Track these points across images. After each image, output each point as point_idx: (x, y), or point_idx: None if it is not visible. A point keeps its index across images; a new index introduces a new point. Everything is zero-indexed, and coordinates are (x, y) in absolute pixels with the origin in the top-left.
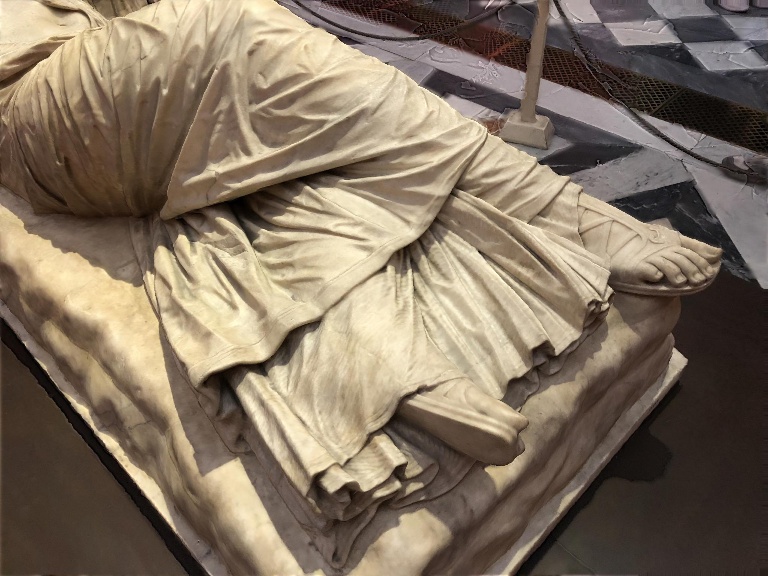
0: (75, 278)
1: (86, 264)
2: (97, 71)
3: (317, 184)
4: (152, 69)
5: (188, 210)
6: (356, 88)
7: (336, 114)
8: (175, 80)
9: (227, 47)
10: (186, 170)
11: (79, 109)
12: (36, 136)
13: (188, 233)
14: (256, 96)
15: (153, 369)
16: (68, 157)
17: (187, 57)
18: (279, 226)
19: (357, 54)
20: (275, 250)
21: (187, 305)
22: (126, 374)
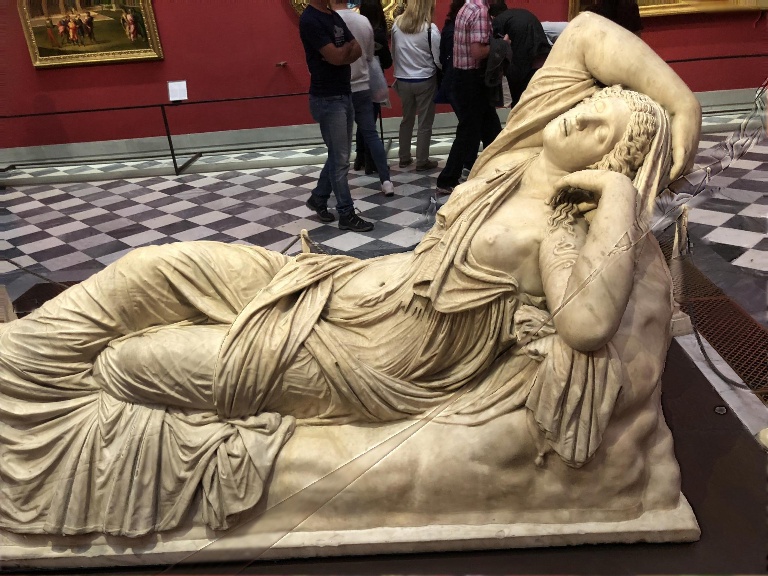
0: None
1: None
2: None
3: None
4: None
5: None
6: None
7: None
8: None
9: None
10: None
11: None
12: None
13: None
14: None
15: None
16: None
17: None
18: None
19: (68, 293)
20: None
21: None
22: None
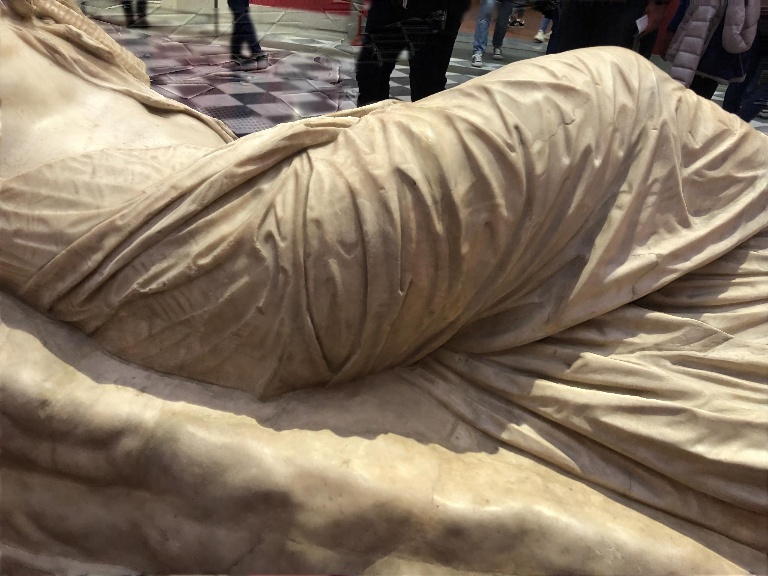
0: (420, 469)
1: (415, 444)
2: (503, 145)
3: (750, 248)
4: (580, 136)
5: (591, 317)
6: (763, 142)
7: (761, 169)
8: (608, 147)
9: (660, 104)
10: (605, 262)
11: (466, 202)
12: (356, 259)
13: (580, 350)
14: (685, 158)
15: (670, 540)
16: (414, 280)
17: (617, 119)
18: (728, 304)
19: None
20: (745, 331)
21: (754, 417)
22: (629, 567)
